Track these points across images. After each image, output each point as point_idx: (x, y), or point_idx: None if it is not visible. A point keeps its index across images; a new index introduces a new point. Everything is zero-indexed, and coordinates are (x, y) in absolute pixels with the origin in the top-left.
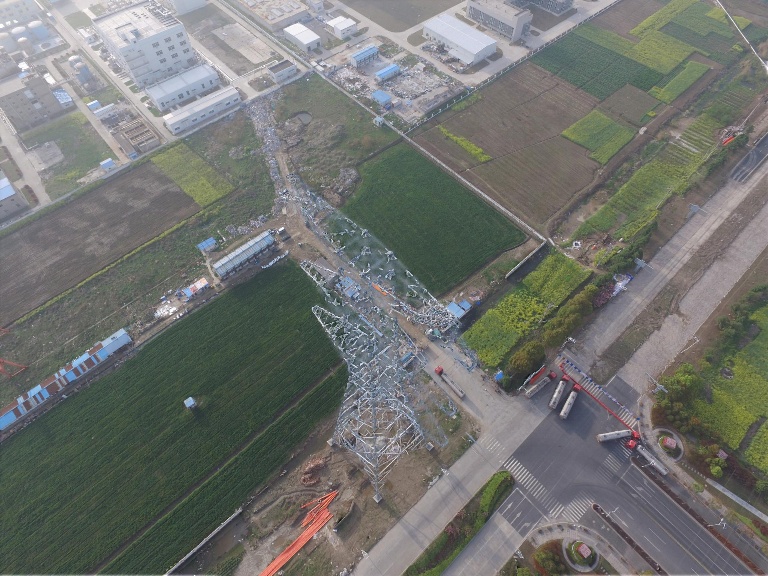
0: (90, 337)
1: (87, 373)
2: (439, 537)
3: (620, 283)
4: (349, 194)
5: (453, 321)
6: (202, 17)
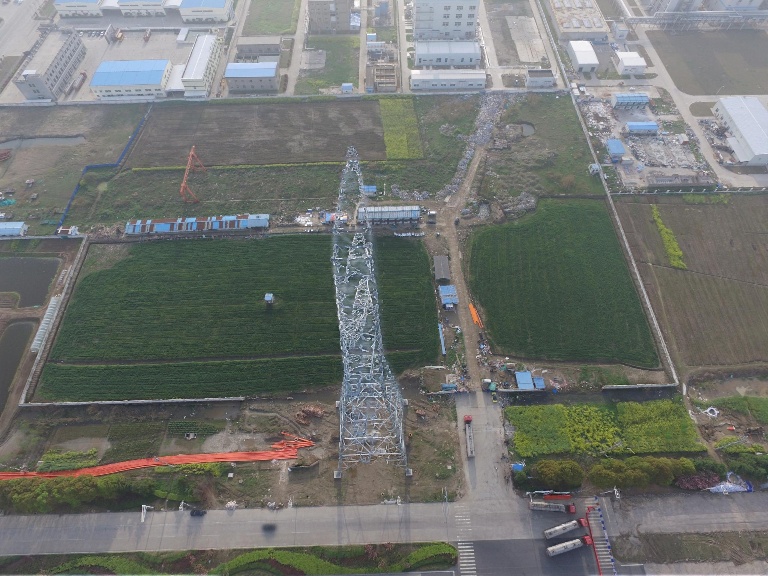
0: (246, 206)
1: (227, 230)
2: (358, 547)
3: (730, 484)
4: (513, 218)
5: (351, 340)
6: (507, 0)
